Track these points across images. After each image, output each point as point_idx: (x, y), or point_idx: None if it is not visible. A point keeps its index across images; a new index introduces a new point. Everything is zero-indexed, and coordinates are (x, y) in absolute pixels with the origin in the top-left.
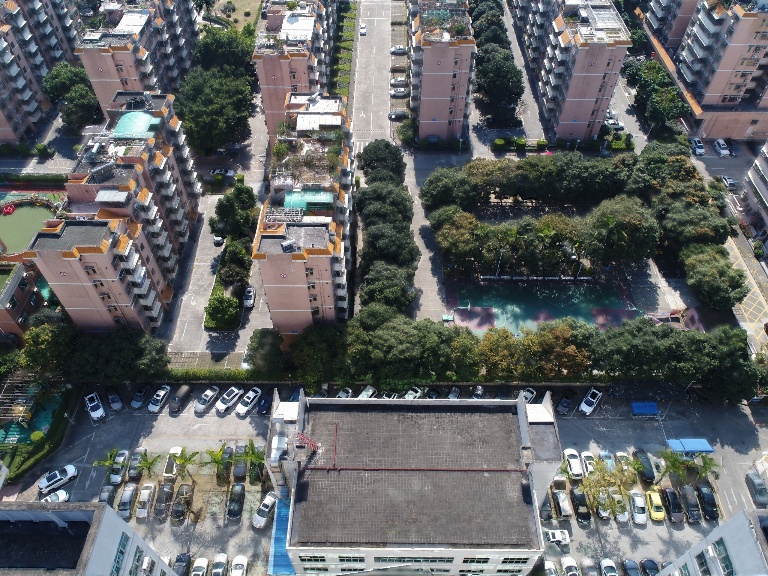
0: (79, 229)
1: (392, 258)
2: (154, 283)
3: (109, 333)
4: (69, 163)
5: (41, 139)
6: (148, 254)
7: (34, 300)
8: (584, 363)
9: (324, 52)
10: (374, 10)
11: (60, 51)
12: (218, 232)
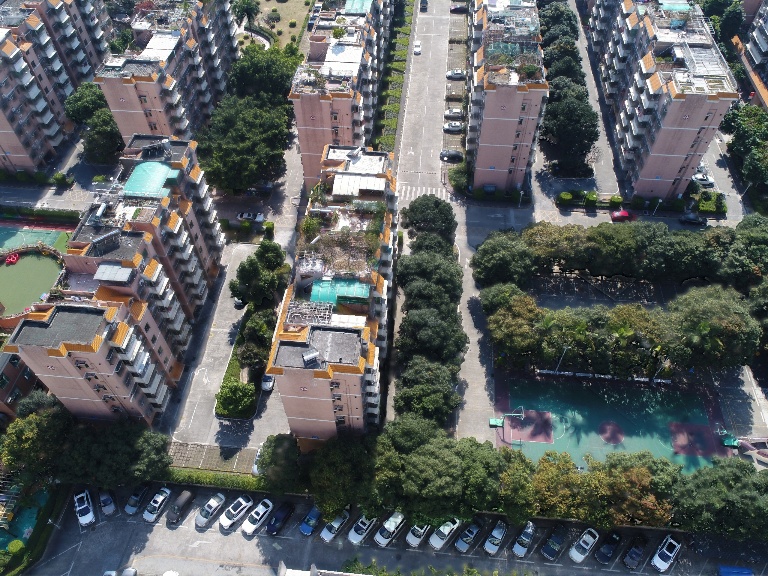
0: (71, 317)
1: (435, 351)
2: (161, 363)
3: (104, 427)
4: (88, 196)
5: (61, 165)
6: (154, 333)
7: (28, 373)
8: (665, 519)
9: (372, 80)
10: (431, 24)
11: (88, 66)
12: (239, 296)
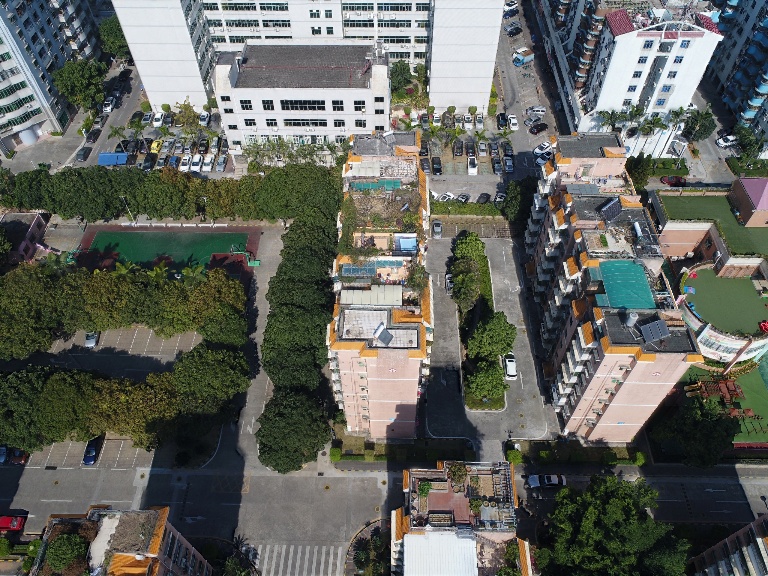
0: (589, 155)
1: None
2: None
3: None
4: None
5: None
6: None
7: None
8: None
9: None
10: None
11: None
12: None
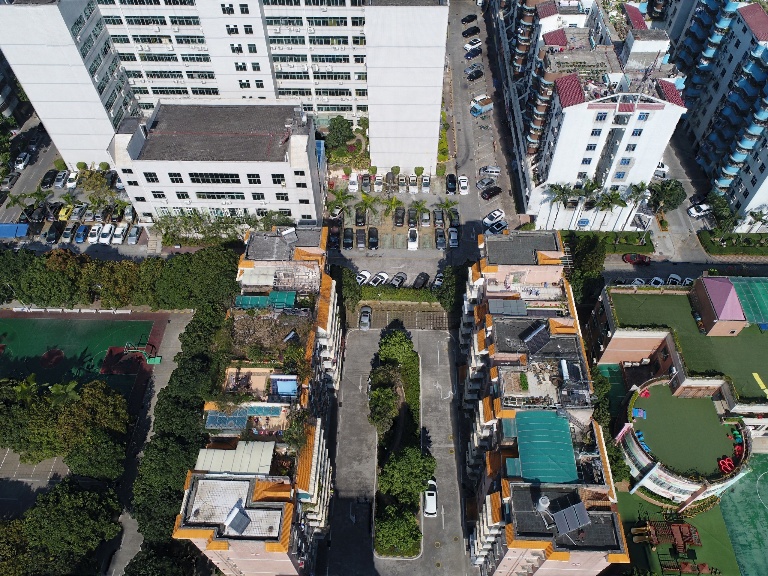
0: (520, 260)
1: None
2: None
3: None
4: None
5: None
6: None
7: None
8: None
9: None
10: None
11: None
12: None
